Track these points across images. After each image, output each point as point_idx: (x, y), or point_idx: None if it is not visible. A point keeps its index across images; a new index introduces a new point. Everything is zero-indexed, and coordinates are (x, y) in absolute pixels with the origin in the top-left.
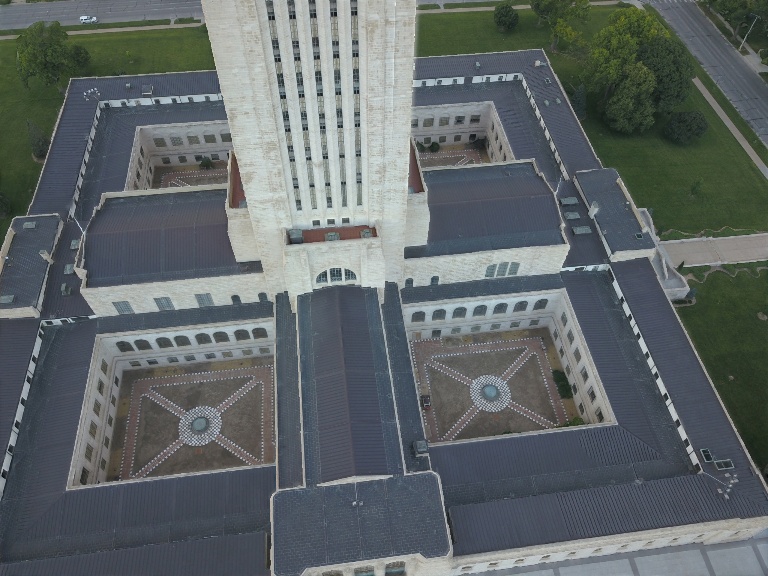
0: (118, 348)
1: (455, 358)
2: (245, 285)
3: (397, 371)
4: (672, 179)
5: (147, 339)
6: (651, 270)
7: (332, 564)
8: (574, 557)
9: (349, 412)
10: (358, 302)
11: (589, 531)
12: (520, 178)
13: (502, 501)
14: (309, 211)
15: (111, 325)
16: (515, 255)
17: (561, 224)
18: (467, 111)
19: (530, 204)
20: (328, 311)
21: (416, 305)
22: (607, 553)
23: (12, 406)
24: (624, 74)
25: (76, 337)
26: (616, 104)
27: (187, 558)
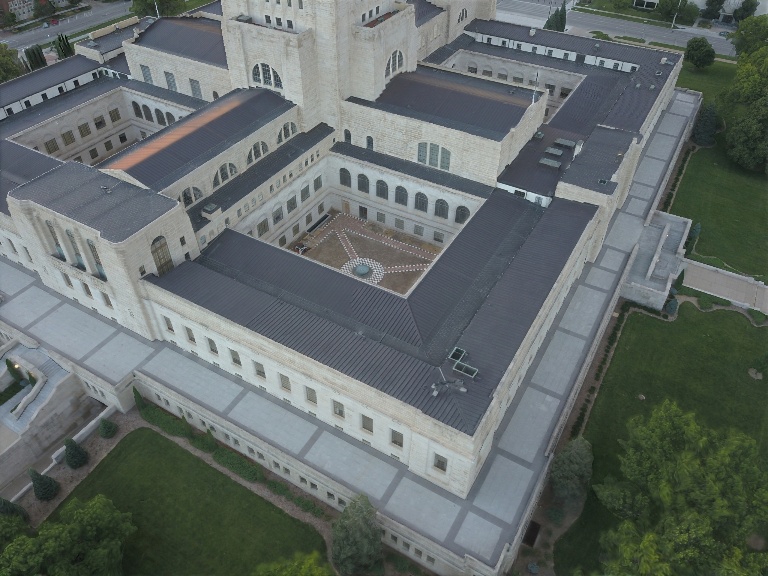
0: (134, 110)
1: (363, 238)
2: (221, 81)
3: (261, 170)
4: (767, 224)
5: (149, 107)
6: (591, 216)
7: (44, 206)
8: (266, 385)
9: (171, 143)
10: (271, 104)
11: (267, 332)
12: (518, 97)
13: (229, 278)
14: (262, 2)
15: (135, 86)
16: (444, 136)
17: (511, 128)
18: (558, 80)
19: (498, 107)
20: (242, 99)
21: (340, 156)
22: (300, 404)
23: (33, 91)
24: (762, 94)
25: (111, 85)
26: (738, 125)
27: (5, 191)
